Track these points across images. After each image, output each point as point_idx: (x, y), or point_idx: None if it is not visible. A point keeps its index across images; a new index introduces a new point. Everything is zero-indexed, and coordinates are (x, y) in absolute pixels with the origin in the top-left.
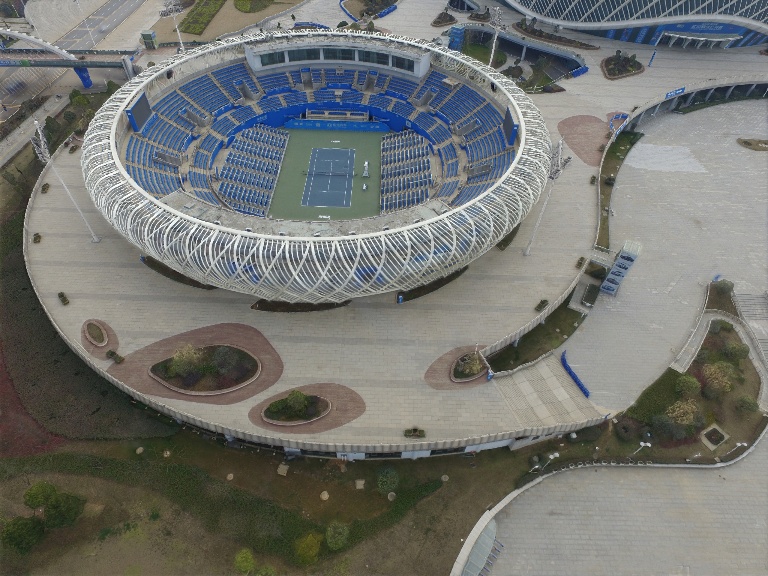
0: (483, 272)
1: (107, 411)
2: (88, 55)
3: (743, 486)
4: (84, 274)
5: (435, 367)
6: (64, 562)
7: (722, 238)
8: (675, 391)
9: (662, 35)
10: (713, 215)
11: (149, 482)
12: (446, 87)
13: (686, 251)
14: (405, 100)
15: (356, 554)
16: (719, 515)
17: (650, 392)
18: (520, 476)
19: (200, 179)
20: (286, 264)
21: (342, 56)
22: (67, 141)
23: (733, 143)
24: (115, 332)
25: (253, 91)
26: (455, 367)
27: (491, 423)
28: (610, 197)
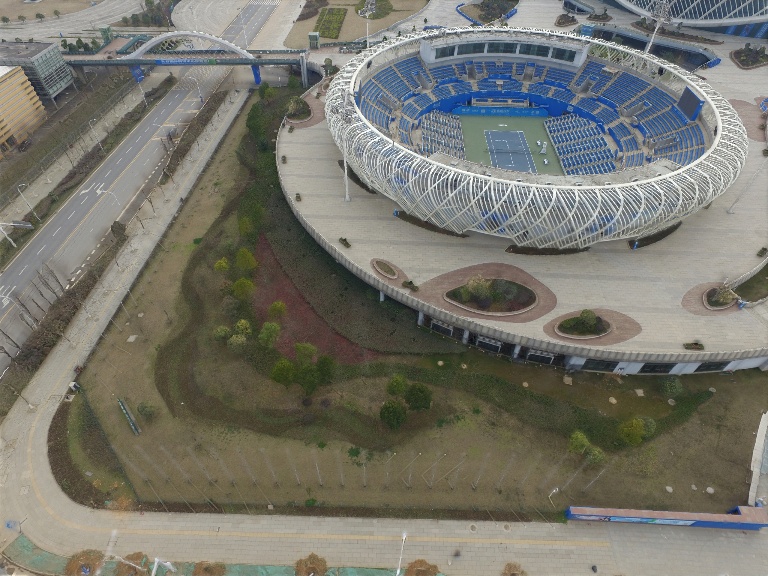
0: (697, 226)
1: (403, 332)
2: (262, 54)
3: None
4: (351, 225)
5: (688, 298)
6: (416, 442)
7: None
8: None
9: None
10: None
11: (462, 385)
12: (605, 75)
13: None
14: (563, 88)
15: (659, 444)
16: None
17: None
18: None
19: None
20: (562, 207)
21: (504, 49)
22: (283, 123)
23: None
24: (400, 268)
25: (427, 81)
26: (707, 298)
27: (757, 341)
28: None
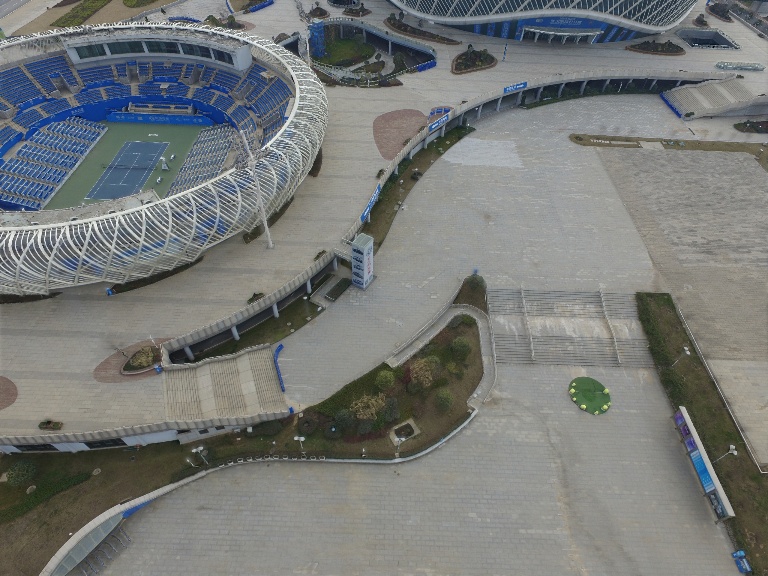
0: (215, 265)
1: None
2: None
3: (414, 482)
4: None
5: (111, 359)
6: None
7: (505, 233)
8: (376, 386)
9: (524, 30)
10: (507, 210)
11: None
12: (264, 80)
13: (461, 246)
14: None
15: None
16: (375, 511)
17: (350, 386)
18: (180, 470)
19: None
20: None
21: (167, 49)
22: None
23: (564, 138)
24: None
25: (71, 84)
26: (129, 359)
27: (137, 416)
28: (409, 191)
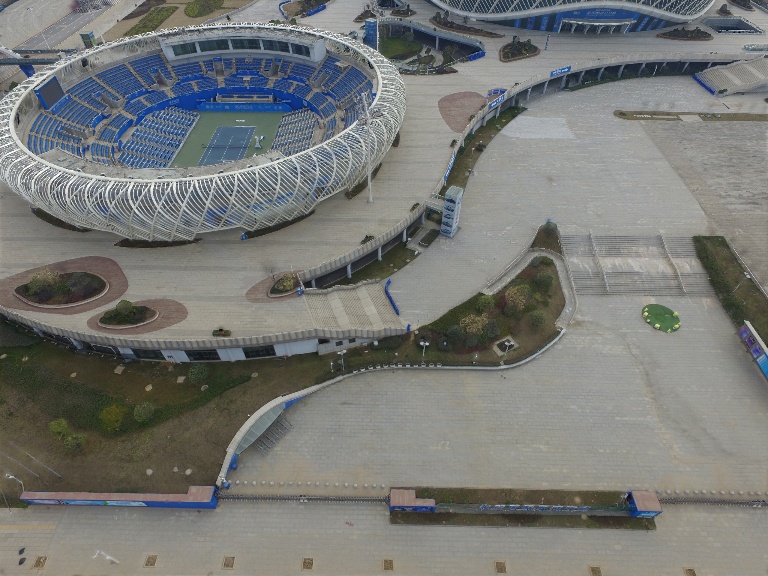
0: (326, 216)
1: None
2: (33, 54)
3: (520, 383)
4: None
5: (257, 286)
6: None
7: (568, 191)
8: (477, 309)
9: (562, 22)
10: (567, 173)
11: (3, 377)
12: (338, 69)
13: (530, 202)
14: (305, 83)
15: (162, 428)
16: (490, 404)
17: (455, 310)
18: (322, 375)
19: (102, 149)
20: (127, 199)
21: (249, 46)
22: None
23: (609, 114)
24: None
25: (167, 78)
26: (273, 286)
27: (290, 326)
28: (476, 160)
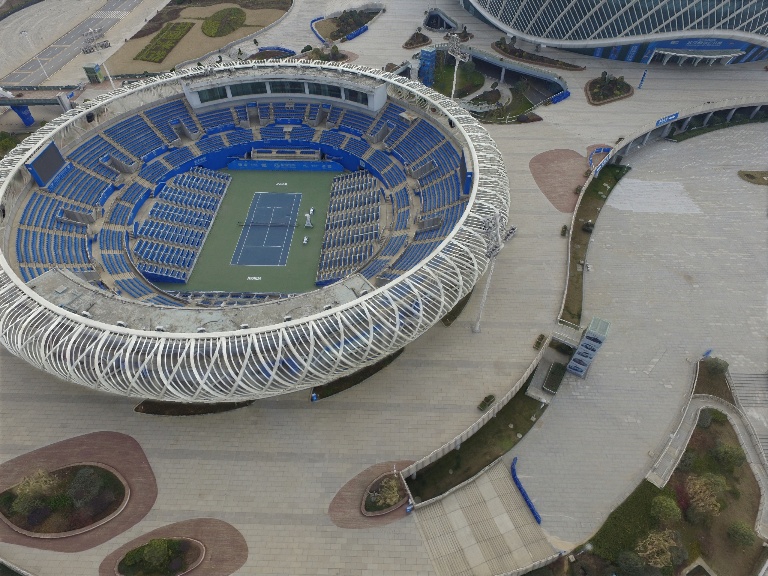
0: (421, 356)
1: None
2: (27, 91)
3: None
4: None
5: (344, 494)
6: None
7: (717, 298)
8: (650, 515)
9: (654, 53)
10: (707, 268)
11: None
12: (403, 122)
13: (673, 316)
14: (360, 136)
15: None
16: None
17: (618, 516)
18: None
19: (113, 238)
20: (156, 371)
21: (291, 89)
22: None
23: (733, 176)
24: None
25: (192, 130)
26: (368, 495)
27: None
28: (587, 247)
